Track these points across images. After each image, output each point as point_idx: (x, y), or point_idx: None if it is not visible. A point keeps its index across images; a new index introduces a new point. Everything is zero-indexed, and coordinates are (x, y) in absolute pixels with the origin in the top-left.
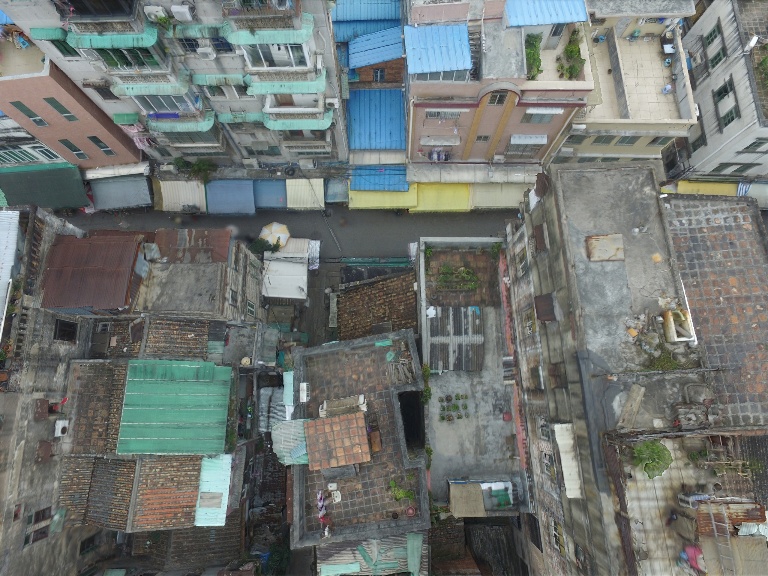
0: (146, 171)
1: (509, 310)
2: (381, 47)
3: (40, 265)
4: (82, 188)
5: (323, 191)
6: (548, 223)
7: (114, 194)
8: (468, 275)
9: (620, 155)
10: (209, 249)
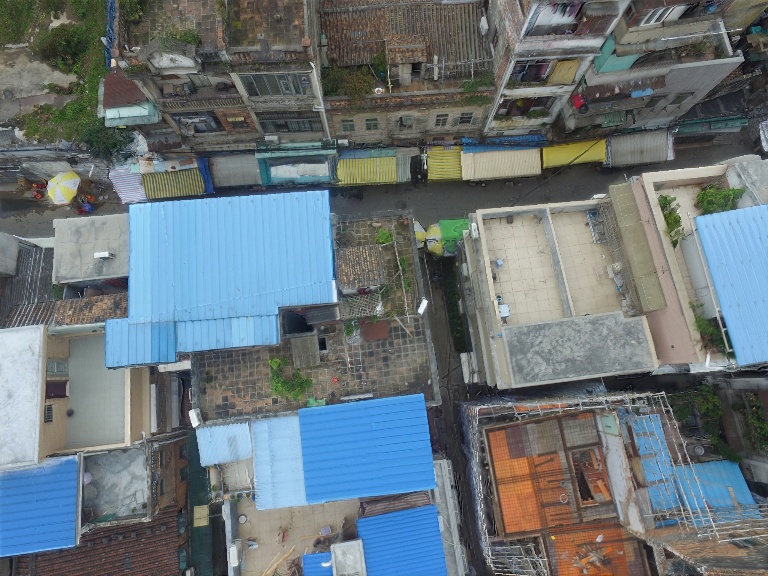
0: None
1: None
2: None
3: None
4: None
5: None
6: None
7: None
8: None
9: None
10: None
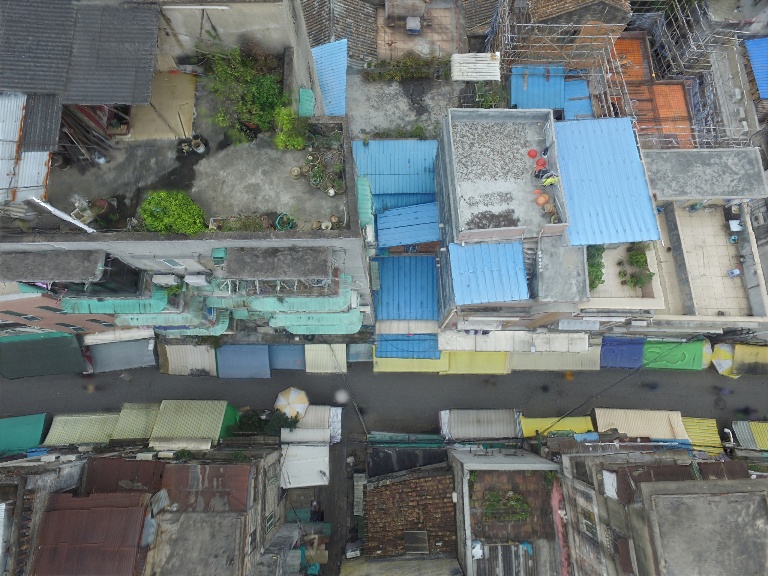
0: (151, 345)
1: (566, 551)
2: (414, 225)
3: (30, 544)
4: (80, 356)
5: (345, 356)
6: (636, 545)
7: (115, 355)
8: (518, 503)
9: (677, 330)
10: (225, 492)
